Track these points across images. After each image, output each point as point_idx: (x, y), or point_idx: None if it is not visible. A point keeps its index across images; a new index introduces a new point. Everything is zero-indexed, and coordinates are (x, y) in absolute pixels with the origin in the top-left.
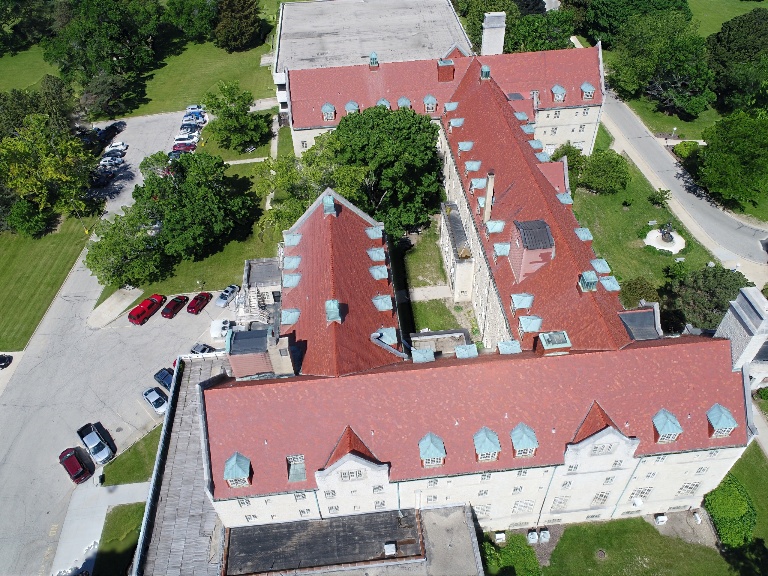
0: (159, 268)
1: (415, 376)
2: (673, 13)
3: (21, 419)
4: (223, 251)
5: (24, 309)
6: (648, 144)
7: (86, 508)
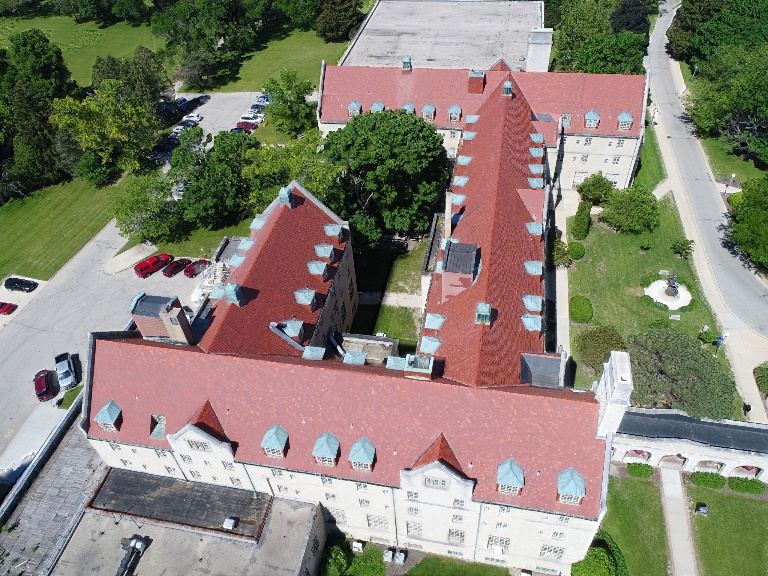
0: (179, 231)
1: (274, 368)
2: (767, 47)
3: (23, 337)
4: (237, 226)
5: (64, 246)
6: (703, 188)
7: (39, 423)
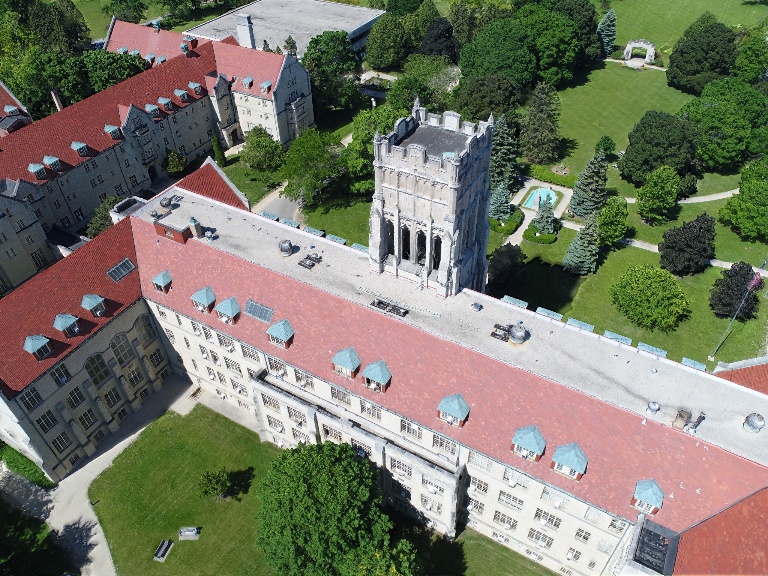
0: None
1: None
2: (432, 58)
3: None
4: None
5: None
6: None
7: None
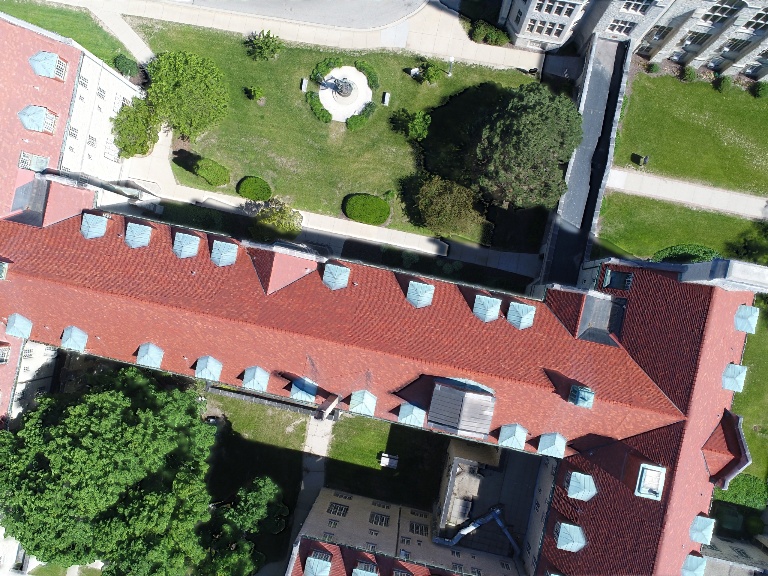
0: None
1: None
2: None
3: None
4: None
5: None
6: None
7: None
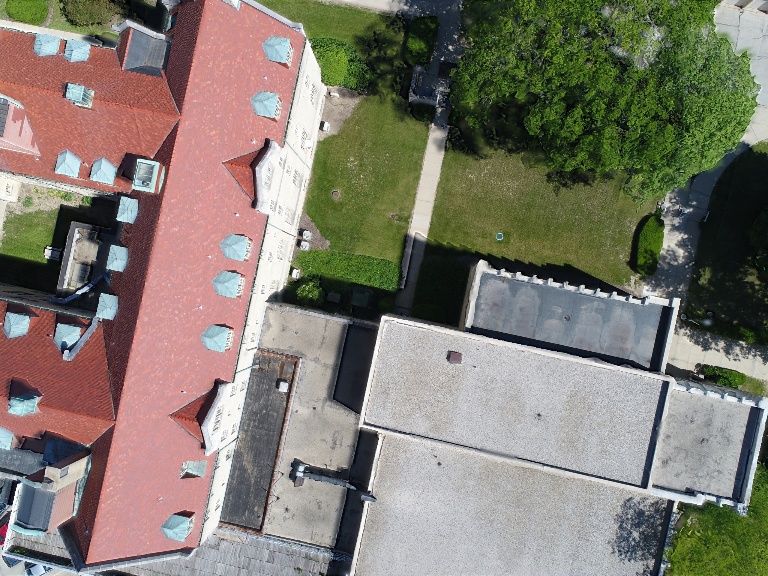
0: None
1: (140, 340)
2: None
3: None
4: None
5: None
6: None
7: None
